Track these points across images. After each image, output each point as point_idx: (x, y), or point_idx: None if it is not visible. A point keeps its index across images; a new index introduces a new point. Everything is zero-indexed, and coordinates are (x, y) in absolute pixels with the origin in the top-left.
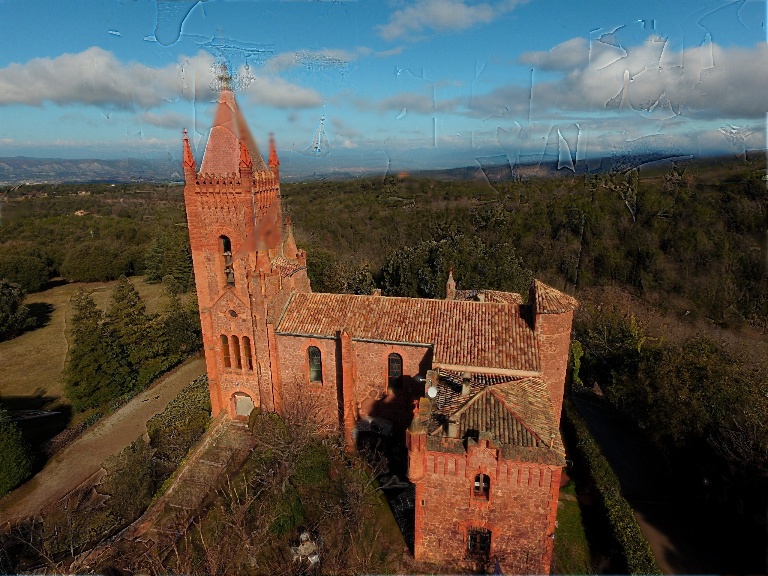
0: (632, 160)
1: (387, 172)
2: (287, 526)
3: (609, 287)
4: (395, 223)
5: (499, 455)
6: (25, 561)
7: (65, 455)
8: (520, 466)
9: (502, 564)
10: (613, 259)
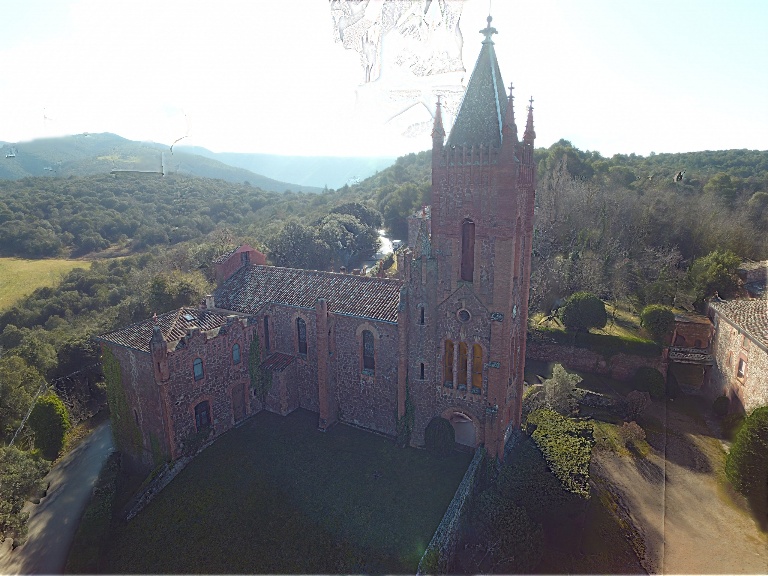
0: None
1: None
2: None
3: None
4: None
5: None
6: None
7: (759, 549)
8: None
9: None
10: None
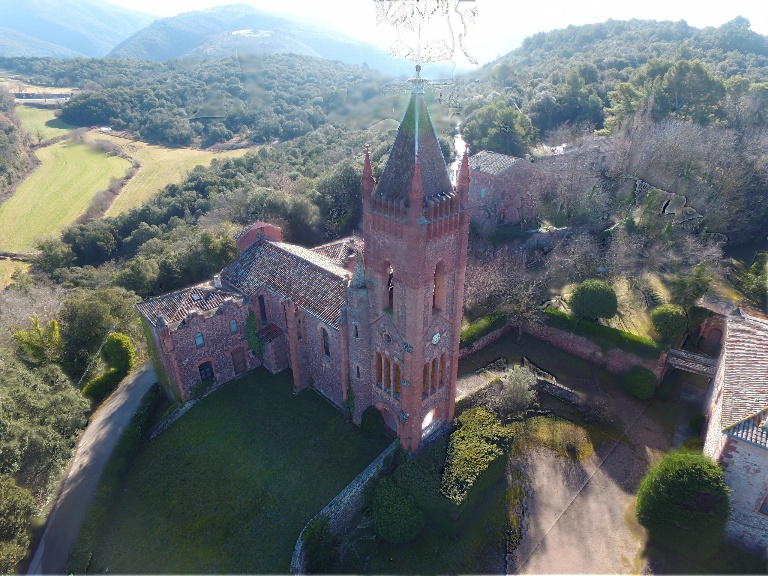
0: None
1: None
2: None
3: None
4: None
5: None
6: (581, 423)
7: (624, 570)
8: None
9: None
10: None
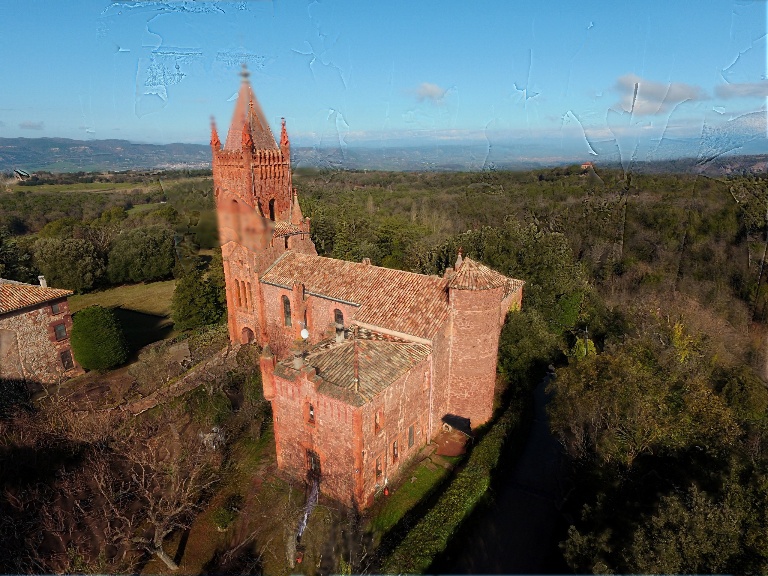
0: (725, 144)
1: (487, 157)
2: (212, 421)
3: (676, 292)
4: (484, 209)
5: (314, 387)
6: None
7: None
8: (331, 401)
9: (330, 488)
10: (718, 264)
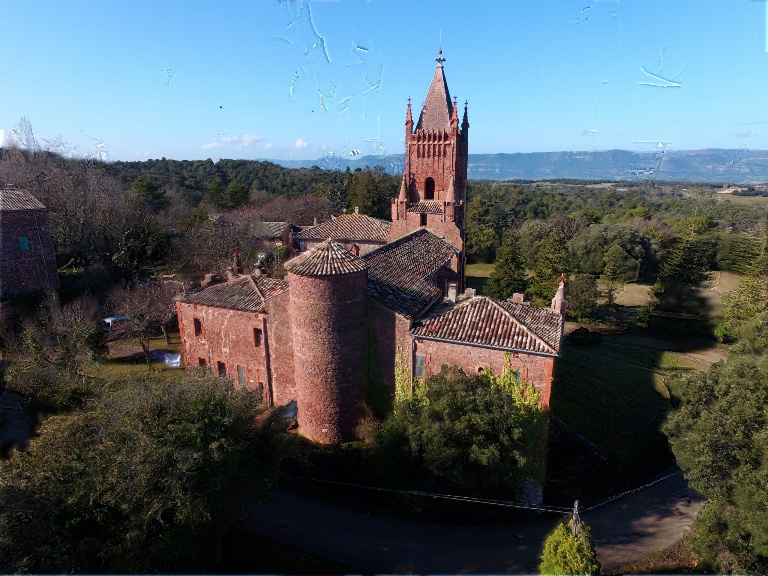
0: None
1: None
2: None
3: None
4: None
5: None
6: None
7: None
8: None
9: None
10: None
